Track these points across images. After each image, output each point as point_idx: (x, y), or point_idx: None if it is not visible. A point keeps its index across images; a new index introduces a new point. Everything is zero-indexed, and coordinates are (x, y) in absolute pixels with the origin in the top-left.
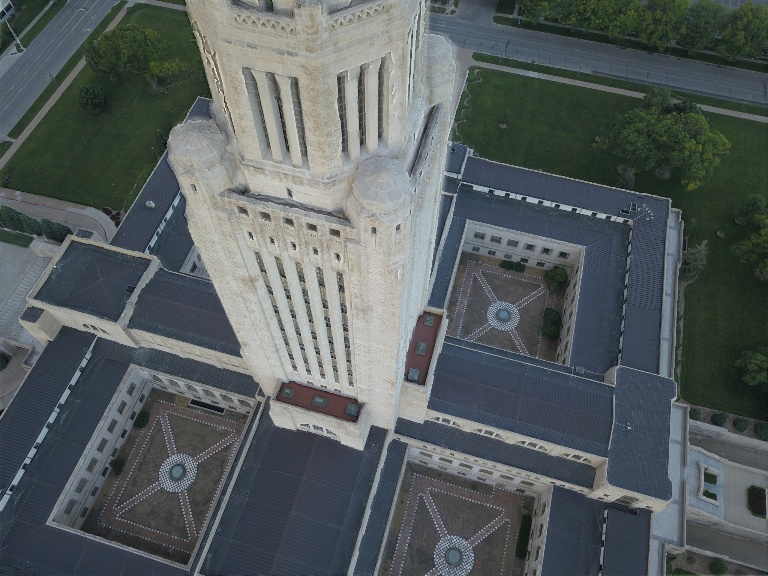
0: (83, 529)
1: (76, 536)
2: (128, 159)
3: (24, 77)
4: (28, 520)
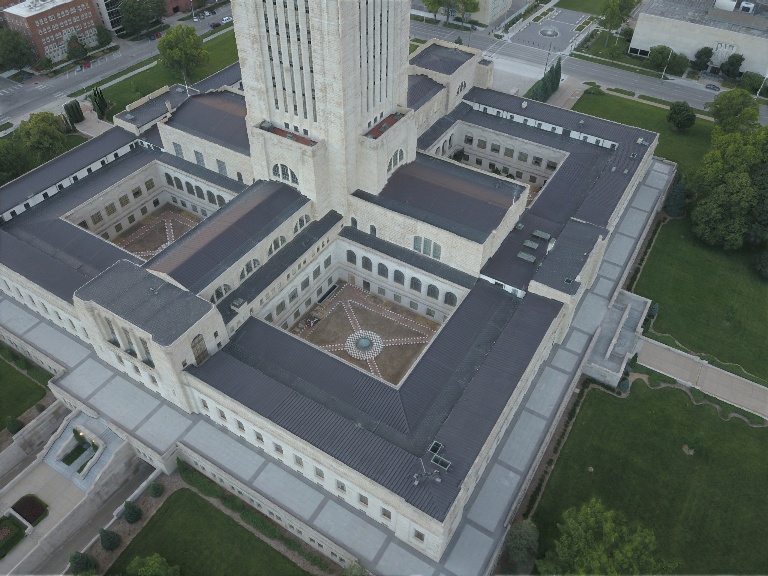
0: None
1: None
2: None
3: None
4: None
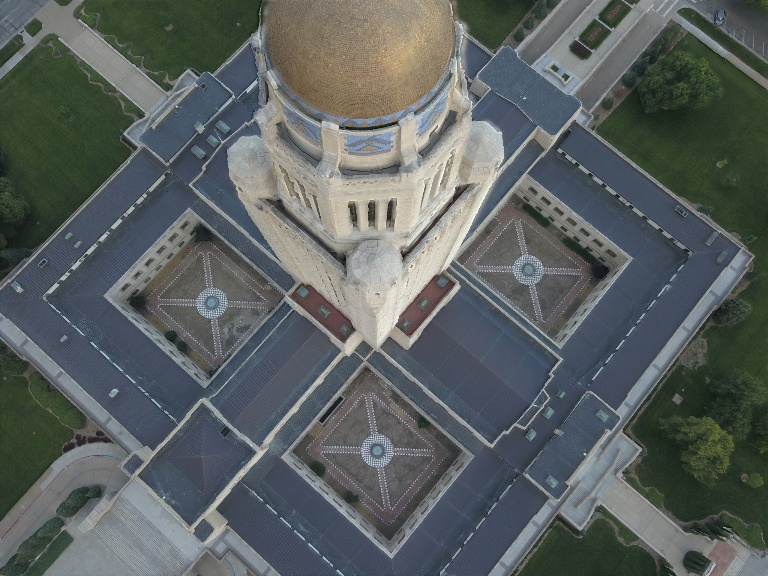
0: (389, 538)
1: (412, 536)
2: (6, 408)
3: None
4: (381, 573)
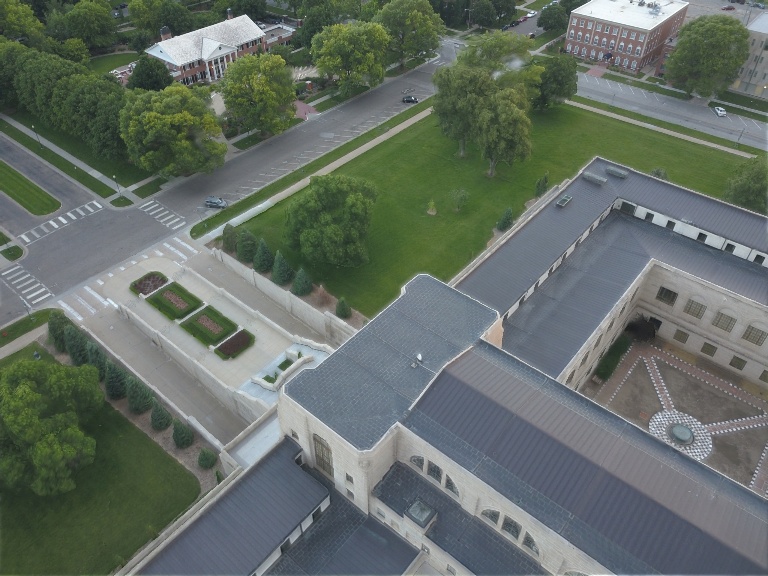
0: None
1: None
2: None
3: None
4: None
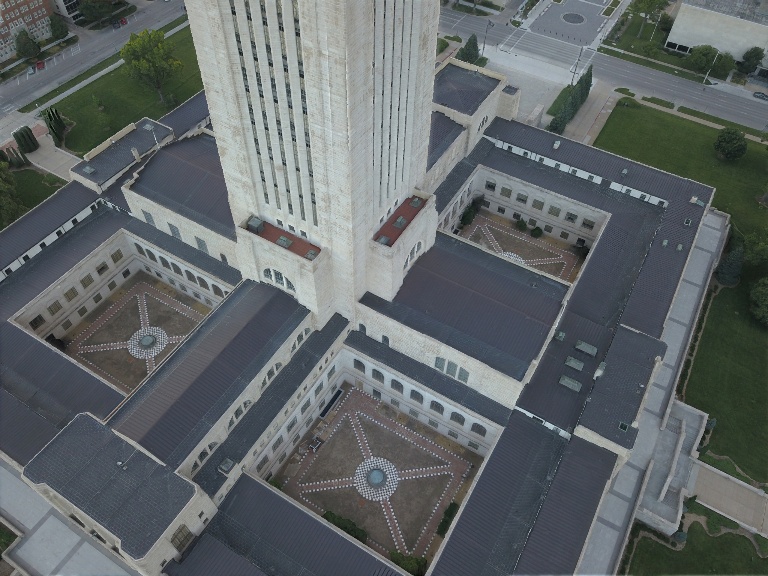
0: None
1: None
2: None
3: (765, 115)
4: None
